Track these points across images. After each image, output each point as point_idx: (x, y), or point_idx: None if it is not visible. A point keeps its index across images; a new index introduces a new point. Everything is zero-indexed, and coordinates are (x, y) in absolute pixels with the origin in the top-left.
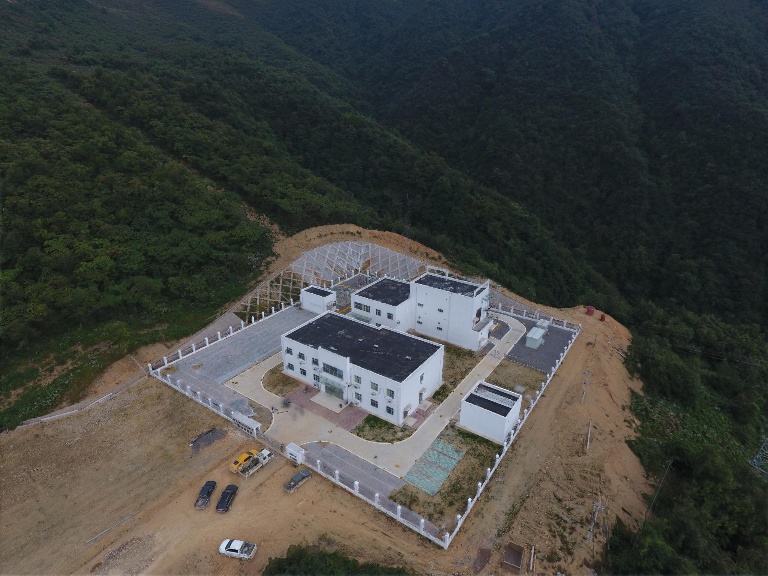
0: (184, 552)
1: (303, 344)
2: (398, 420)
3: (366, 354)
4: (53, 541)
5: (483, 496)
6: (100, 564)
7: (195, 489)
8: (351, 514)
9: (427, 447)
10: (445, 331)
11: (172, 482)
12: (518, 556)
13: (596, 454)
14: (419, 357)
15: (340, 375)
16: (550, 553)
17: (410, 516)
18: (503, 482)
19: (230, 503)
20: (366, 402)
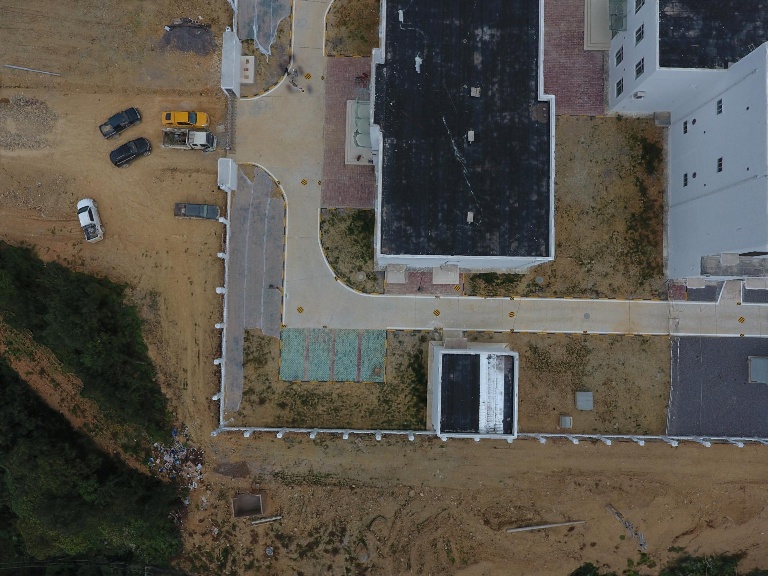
0: (63, 168)
1: (384, 5)
2: None
3: (437, 135)
4: None
5: (319, 436)
6: (7, 102)
7: (124, 101)
8: (199, 303)
9: (358, 327)
10: (684, 195)
11: (110, 67)
12: (259, 505)
13: (506, 543)
14: (491, 232)
15: None
16: (287, 535)
17: (235, 370)
18: (358, 450)
19: (125, 162)
20: None
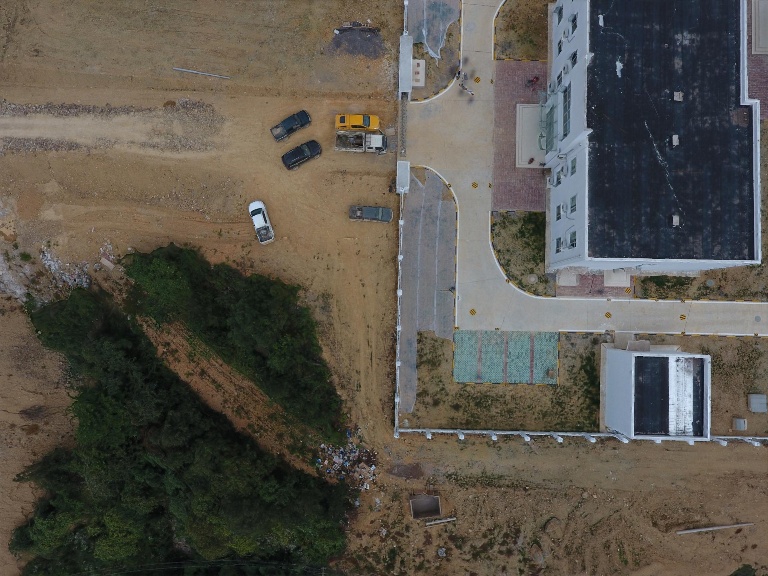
0: (231, 170)
1: (589, 9)
2: (553, 264)
3: (640, 139)
4: (155, 34)
5: None
6: (174, 104)
7: (292, 104)
8: (371, 305)
9: (531, 330)
10: None
11: (280, 71)
12: (434, 506)
13: (674, 545)
14: (694, 236)
15: (566, 130)
16: (461, 536)
17: (409, 371)
18: (532, 452)
19: (297, 165)
20: (557, 196)
